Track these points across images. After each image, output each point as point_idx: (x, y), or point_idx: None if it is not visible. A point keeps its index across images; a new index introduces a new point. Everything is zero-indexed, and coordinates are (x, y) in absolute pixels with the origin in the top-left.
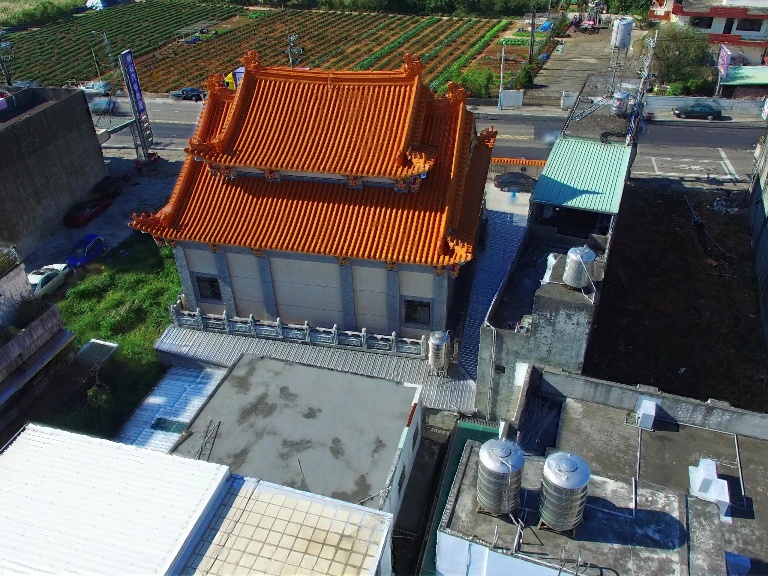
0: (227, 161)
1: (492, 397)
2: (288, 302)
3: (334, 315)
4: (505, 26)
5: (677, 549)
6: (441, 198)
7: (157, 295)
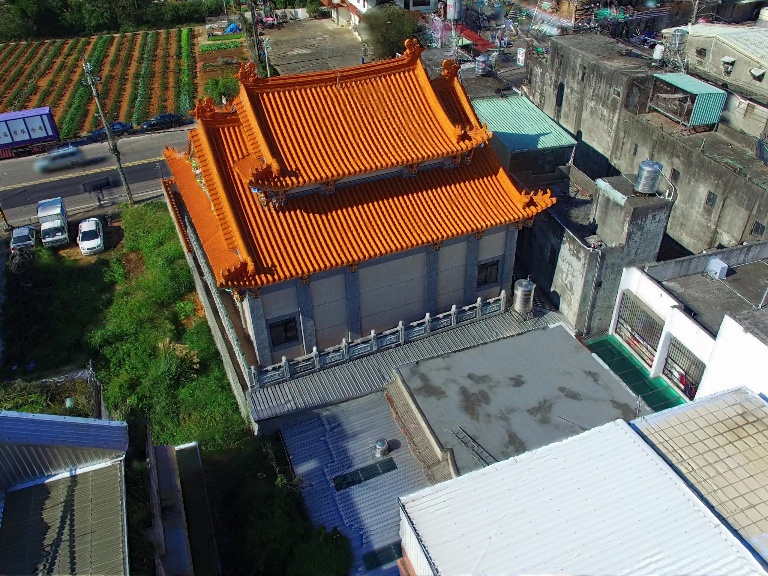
0: (295, 182)
1: (590, 313)
2: (371, 312)
3: (415, 307)
4: (191, 34)
5: None
6: (486, 163)
7: (132, 388)
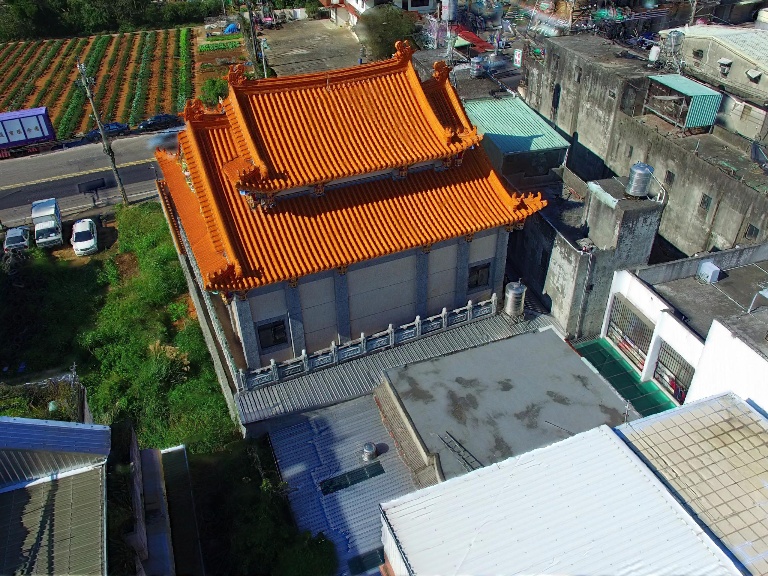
0: (283, 185)
1: (581, 316)
2: (361, 315)
3: (405, 310)
4: (190, 34)
5: None
6: (477, 165)
7: (122, 390)
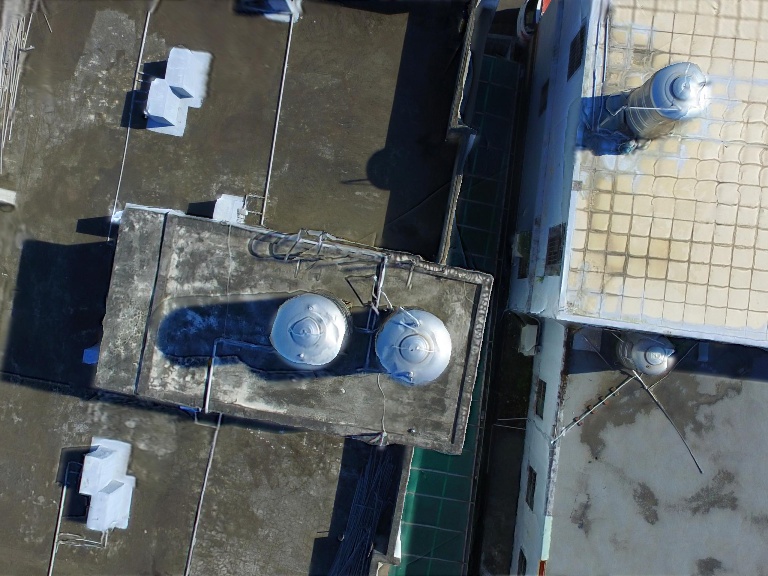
0: None
1: None
2: None
3: None
4: None
5: (168, 299)
6: None
7: None
